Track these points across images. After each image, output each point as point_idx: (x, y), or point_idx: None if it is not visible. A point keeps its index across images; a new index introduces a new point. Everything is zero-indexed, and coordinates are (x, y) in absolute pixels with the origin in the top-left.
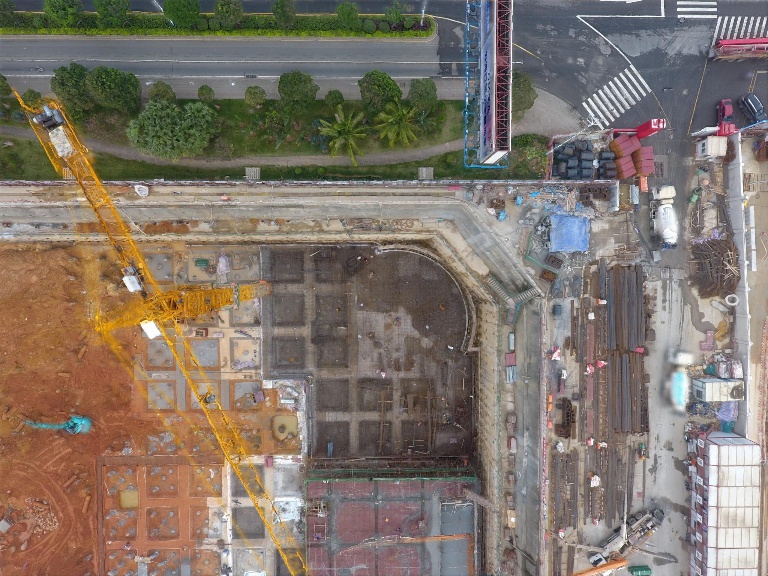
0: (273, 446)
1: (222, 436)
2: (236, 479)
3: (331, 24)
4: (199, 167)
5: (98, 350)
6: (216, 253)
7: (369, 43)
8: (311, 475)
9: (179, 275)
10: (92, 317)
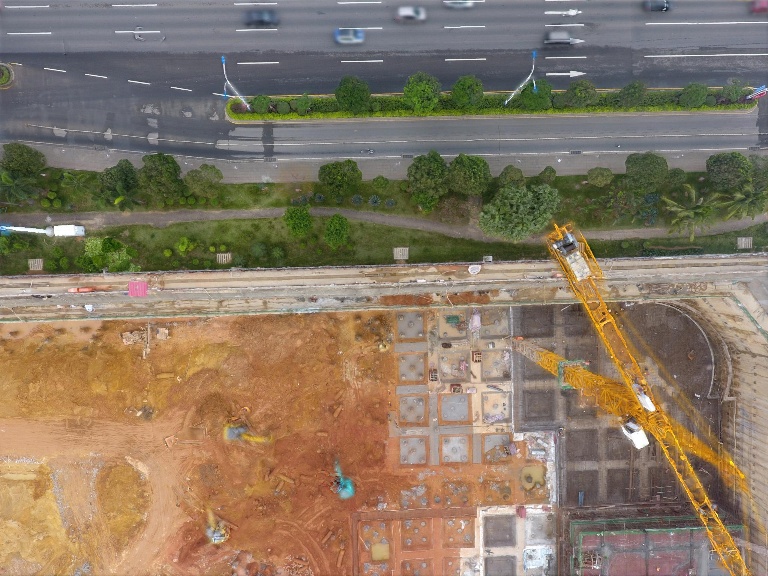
0: (524, 496)
1: (474, 488)
2: (487, 529)
3: (659, 100)
4: (525, 243)
5: (353, 409)
6: (467, 310)
7: (691, 116)
8: (575, 526)
9: (432, 333)
10: (348, 377)
